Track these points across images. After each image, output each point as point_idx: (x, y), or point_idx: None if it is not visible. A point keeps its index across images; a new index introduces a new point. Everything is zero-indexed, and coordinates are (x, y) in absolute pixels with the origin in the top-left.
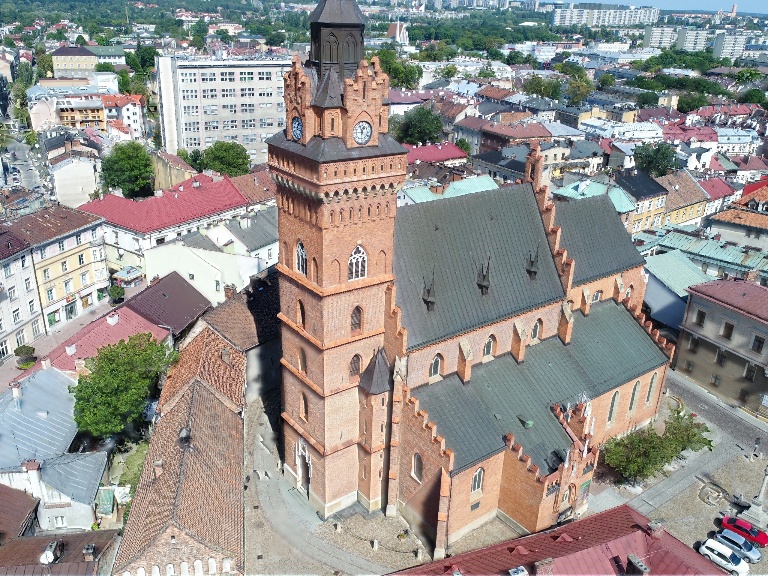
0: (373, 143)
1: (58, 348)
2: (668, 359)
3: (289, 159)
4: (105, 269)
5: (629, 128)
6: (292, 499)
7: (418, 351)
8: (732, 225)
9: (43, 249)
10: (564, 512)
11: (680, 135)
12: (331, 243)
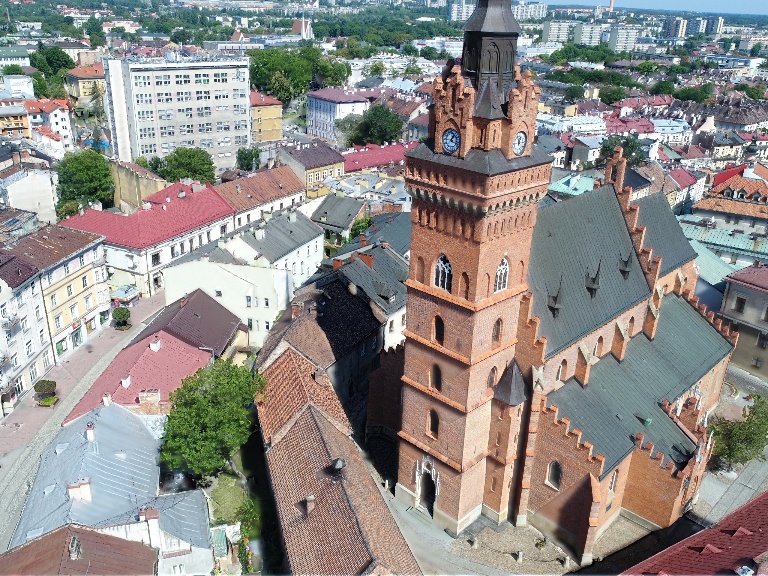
0: (526, 153)
1: (99, 381)
2: (732, 346)
3: (439, 172)
4: (107, 290)
5: (576, 122)
6: (414, 519)
7: (551, 359)
8: (713, 213)
9: (50, 273)
10: (687, 504)
11: (621, 127)
12: (485, 257)
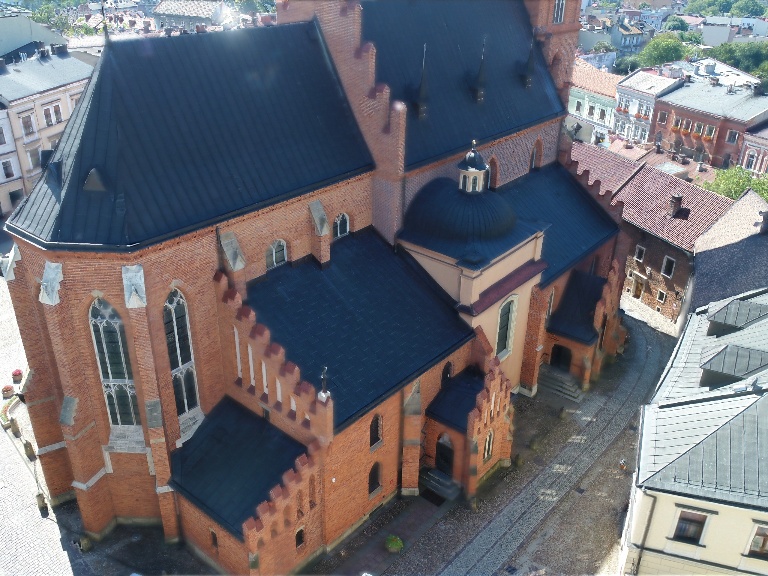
0: None
1: None
2: None
3: None
4: None
5: None
6: None
7: None
8: None
9: None
10: None
11: None
12: None
